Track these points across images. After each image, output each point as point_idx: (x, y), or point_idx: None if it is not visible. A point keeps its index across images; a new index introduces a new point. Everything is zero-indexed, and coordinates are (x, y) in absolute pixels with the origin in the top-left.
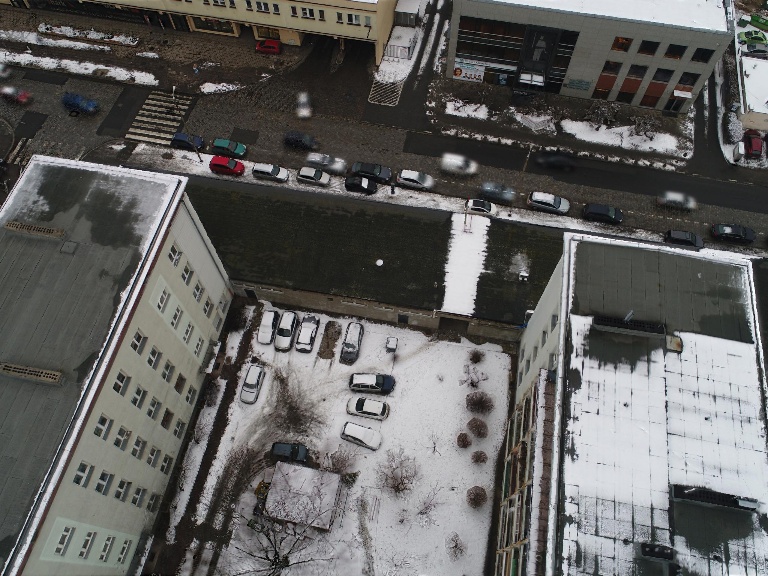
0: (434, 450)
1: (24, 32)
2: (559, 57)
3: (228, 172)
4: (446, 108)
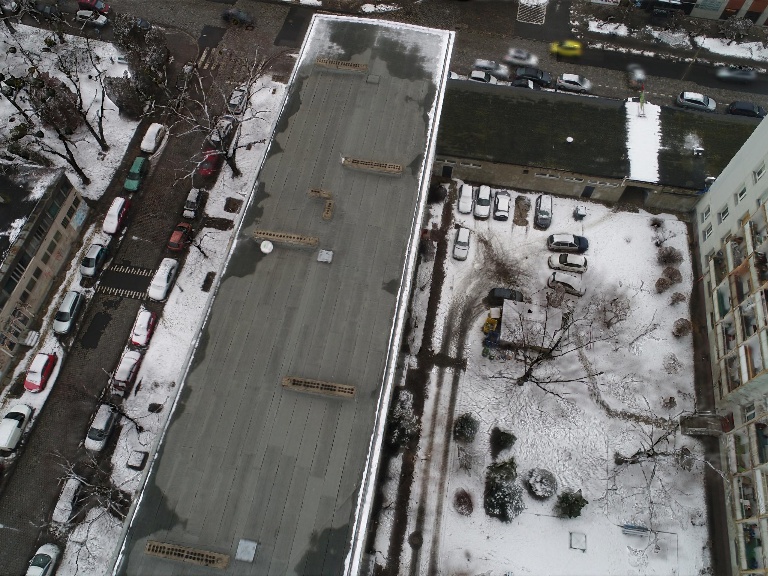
0: (641, 289)
1: None
2: None
3: None
4: (589, 26)
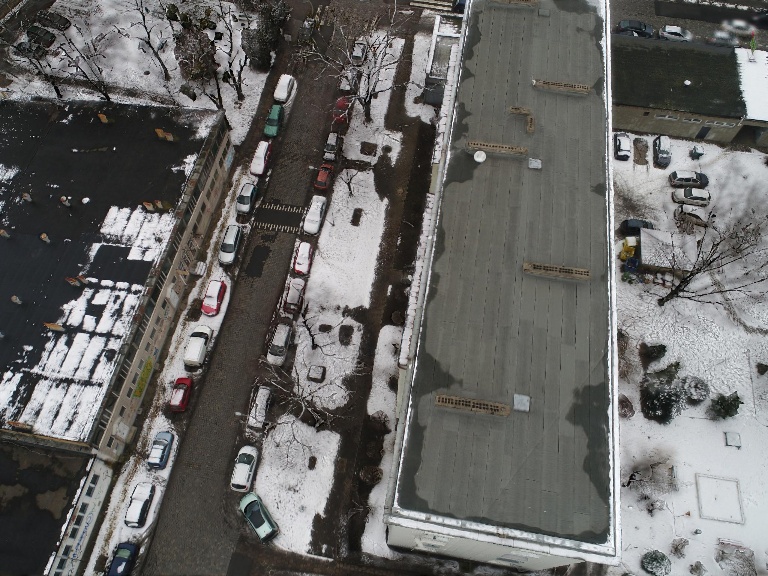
0: (767, 218)
1: None
2: None
3: None
4: None
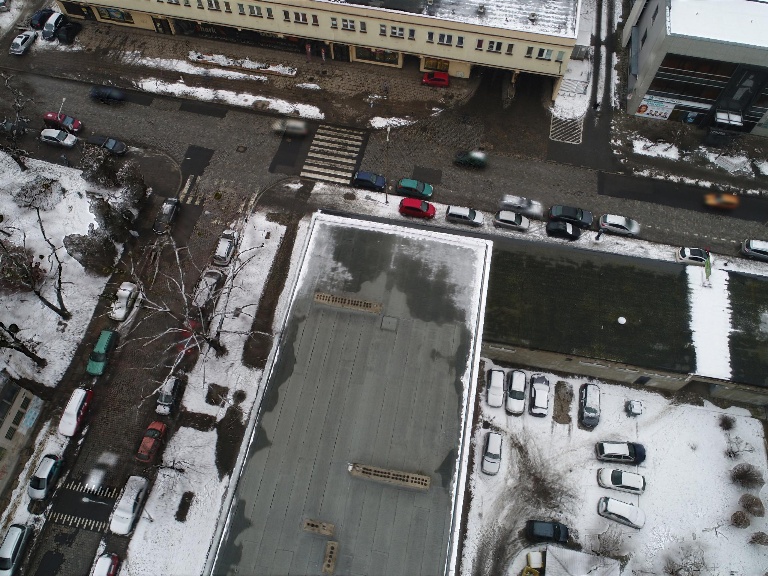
0: (716, 532)
1: (173, 60)
2: (764, 96)
3: (419, 215)
4: (633, 147)
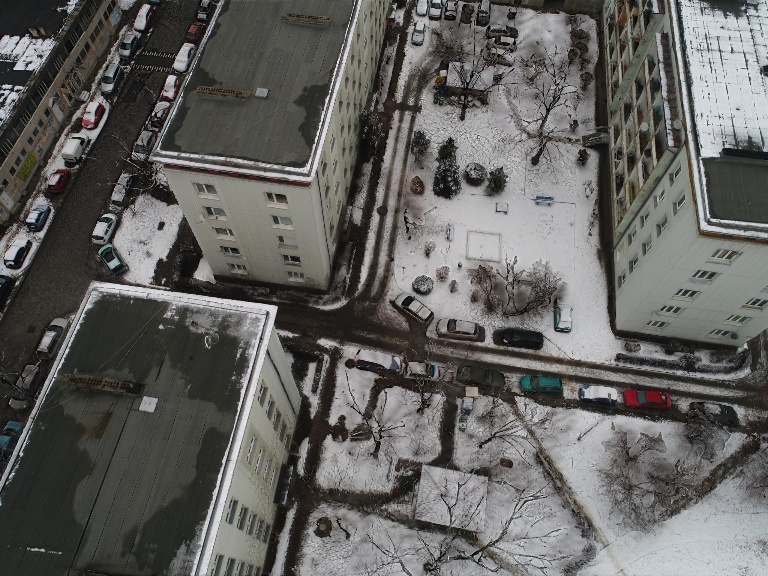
0: (555, 53)
1: None
2: None
3: None
4: None
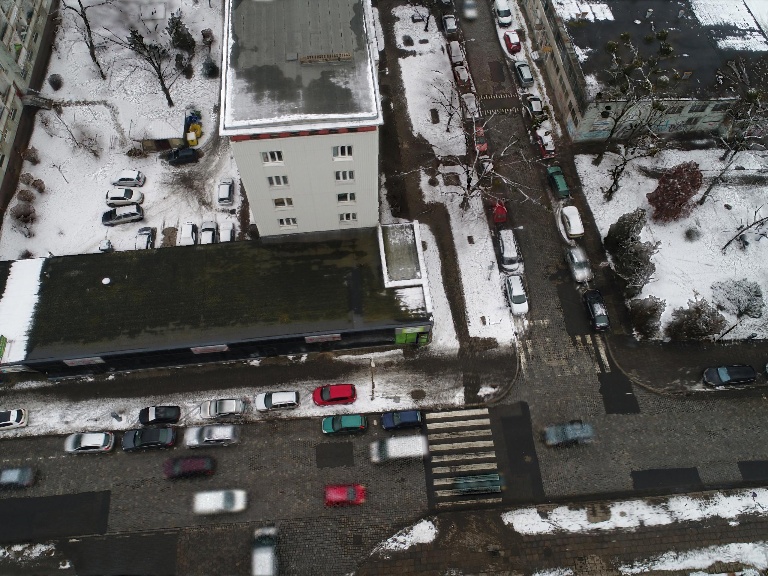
0: (60, 168)
1: None
2: None
3: None
4: None
